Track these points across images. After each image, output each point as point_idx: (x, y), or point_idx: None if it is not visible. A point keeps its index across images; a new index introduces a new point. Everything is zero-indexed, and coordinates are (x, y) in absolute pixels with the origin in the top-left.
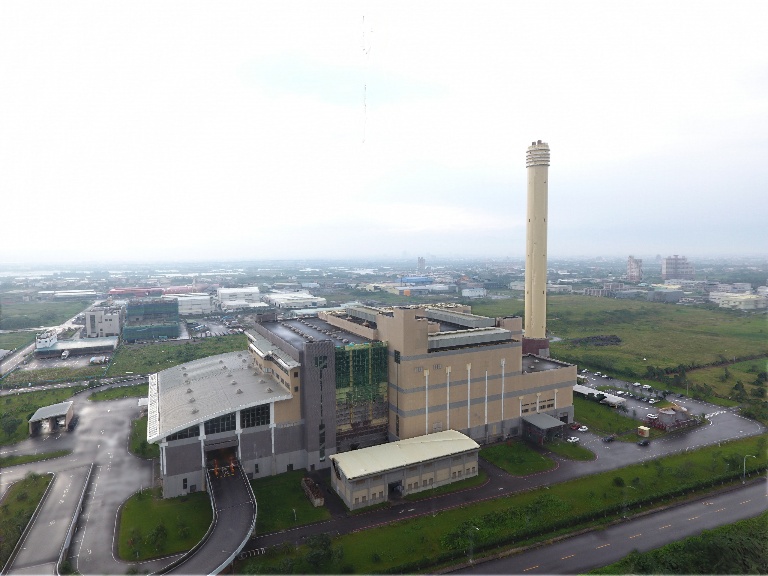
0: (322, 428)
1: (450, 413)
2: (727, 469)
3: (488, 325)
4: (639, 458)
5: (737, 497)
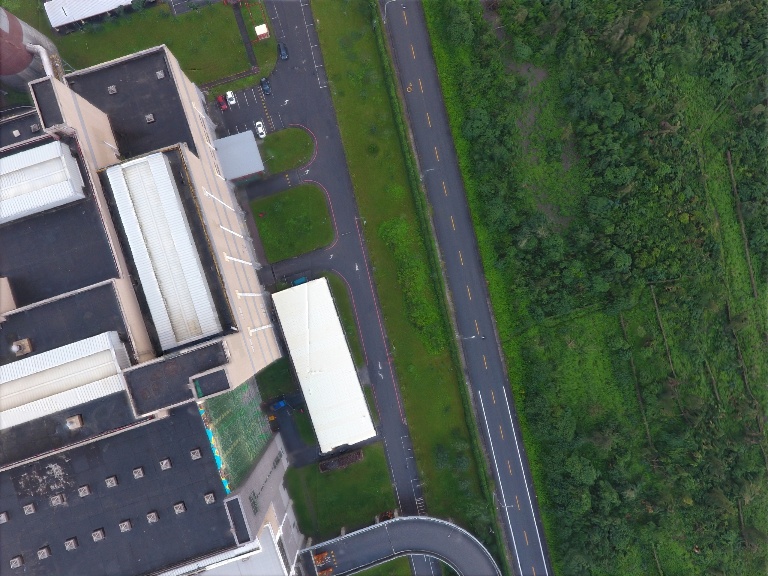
0: (274, 465)
1: (253, 292)
2: (362, 16)
3: (72, 162)
4: (319, 85)
5: (405, 52)
